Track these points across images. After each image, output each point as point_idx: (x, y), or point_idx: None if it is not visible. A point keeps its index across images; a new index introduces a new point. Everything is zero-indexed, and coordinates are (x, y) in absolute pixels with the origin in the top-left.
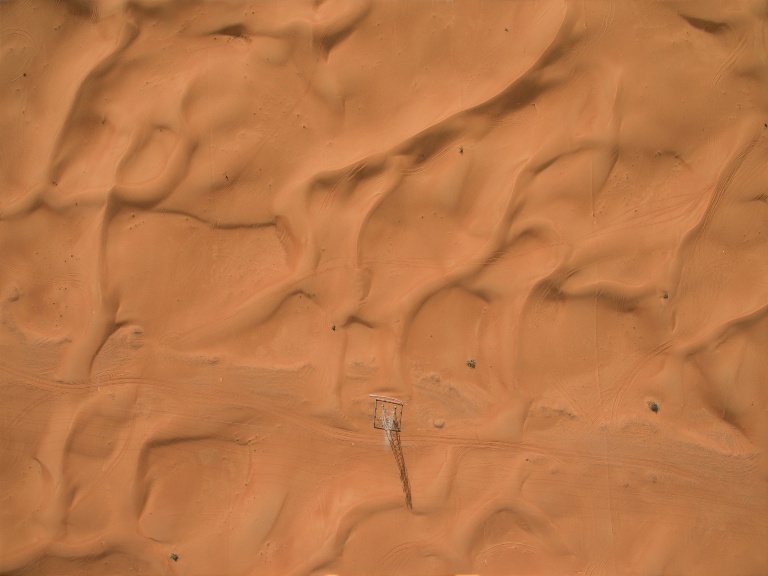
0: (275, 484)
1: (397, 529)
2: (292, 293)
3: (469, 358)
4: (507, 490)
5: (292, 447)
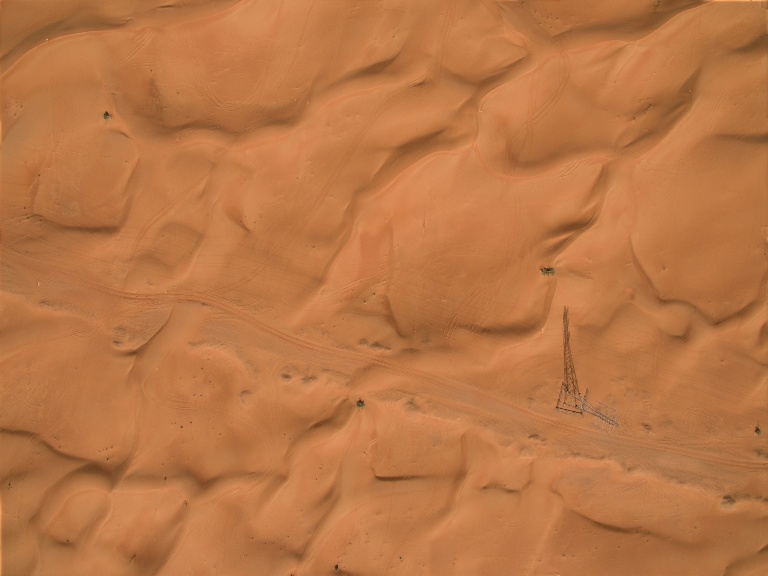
0: (2, 173)
1: None
2: None
3: None
4: None
5: None
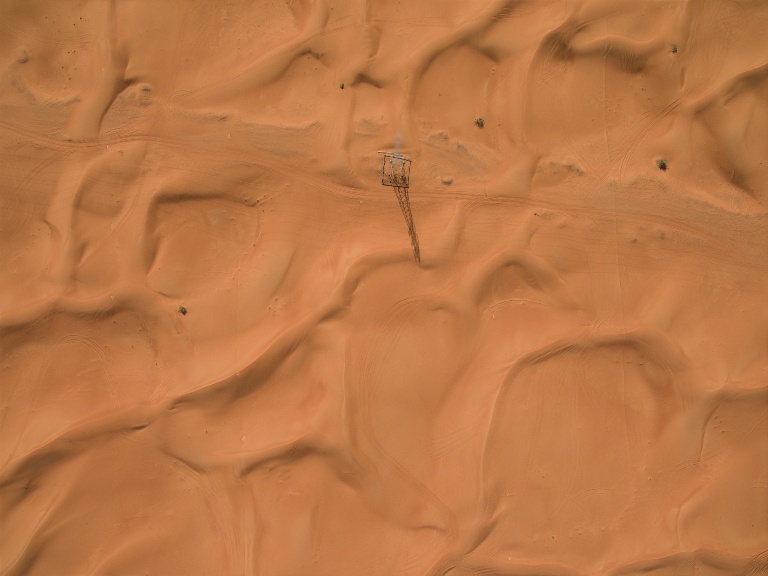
0: (283, 240)
1: (405, 282)
2: (301, 53)
3: (477, 116)
4: (515, 242)
5: (300, 205)
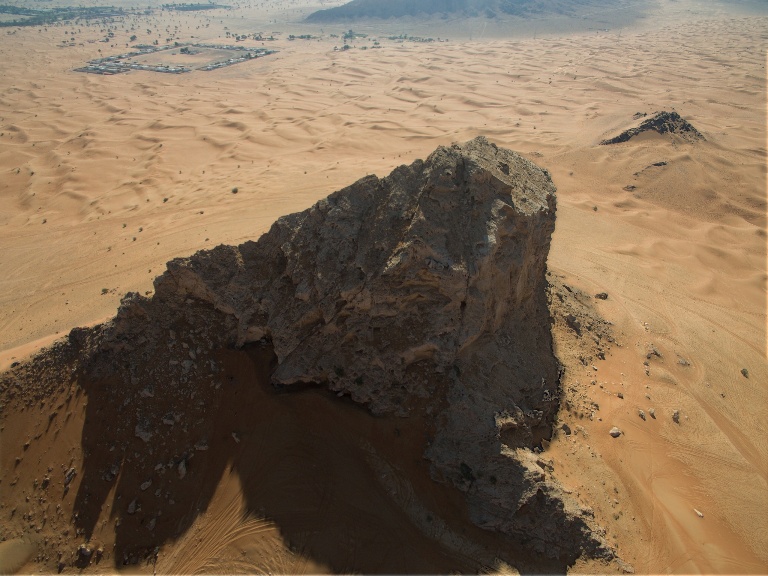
0: None
1: None
2: None
3: None
4: None
5: None
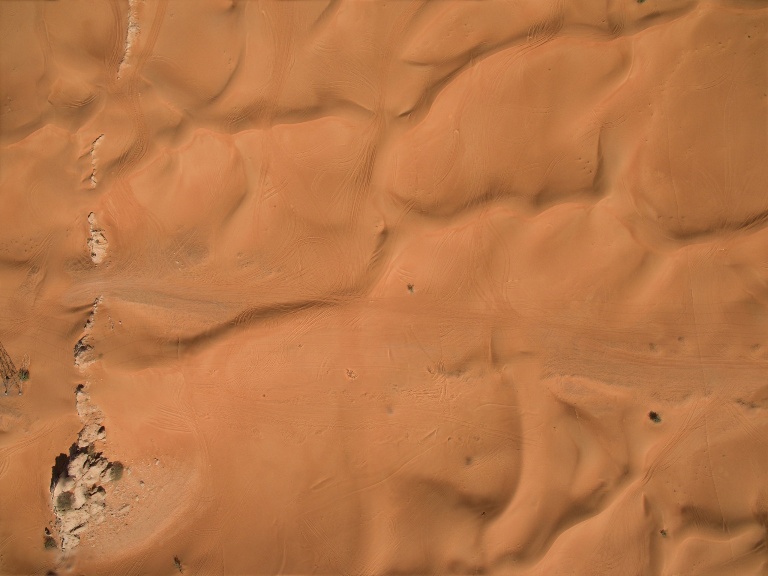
0: None
1: None
2: None
3: None
4: None
5: None
